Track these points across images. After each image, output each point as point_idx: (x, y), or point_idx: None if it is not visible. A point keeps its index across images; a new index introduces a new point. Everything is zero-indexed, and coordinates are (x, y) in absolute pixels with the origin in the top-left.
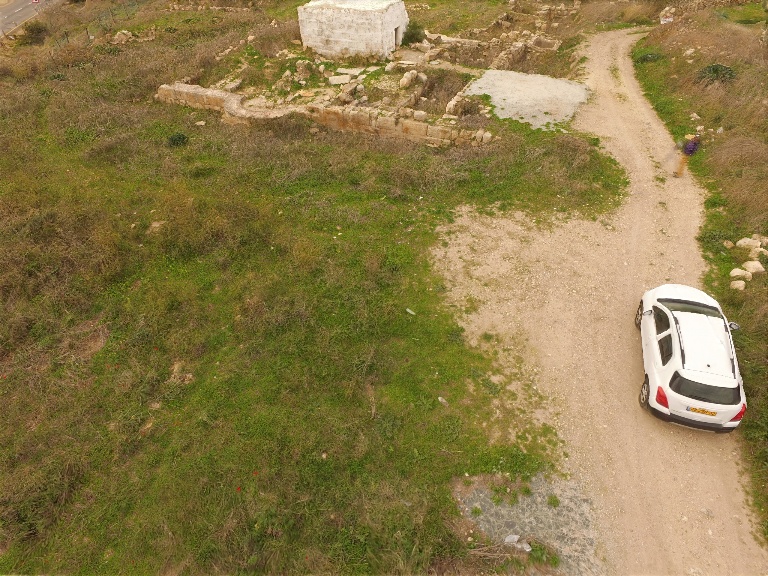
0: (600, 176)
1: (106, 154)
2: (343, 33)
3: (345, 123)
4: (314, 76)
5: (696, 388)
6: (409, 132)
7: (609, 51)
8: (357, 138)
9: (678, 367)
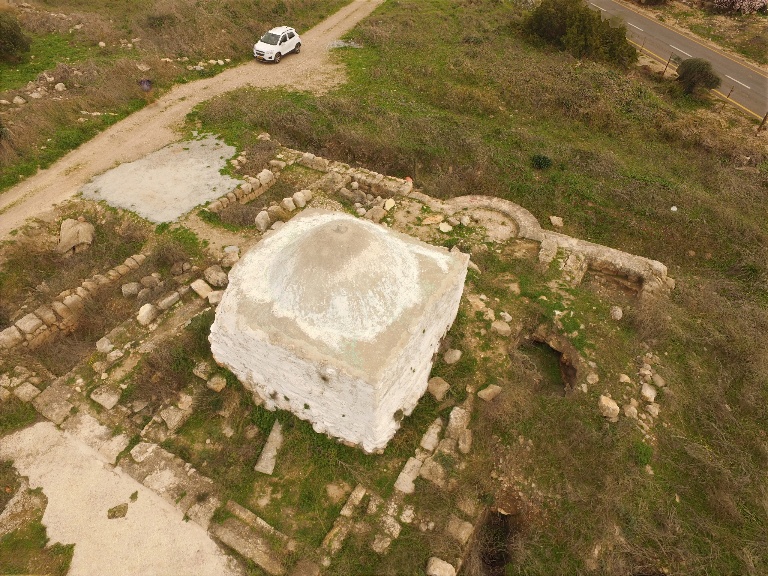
0: None
1: None
2: None
3: None
4: None
5: None
6: None
7: None
8: None
9: None
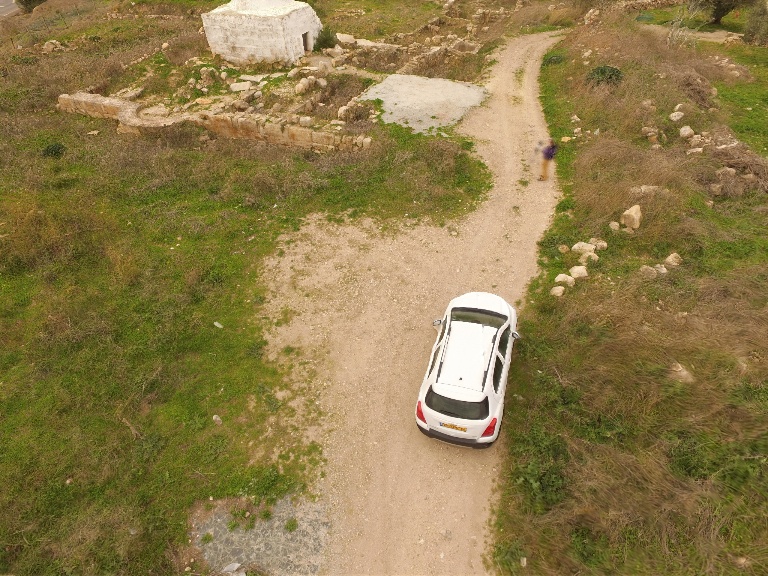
0: (466, 180)
1: None
2: (247, 39)
3: (235, 130)
4: (217, 83)
5: (446, 403)
6: (296, 138)
7: (523, 54)
8: (245, 145)
9: (433, 381)
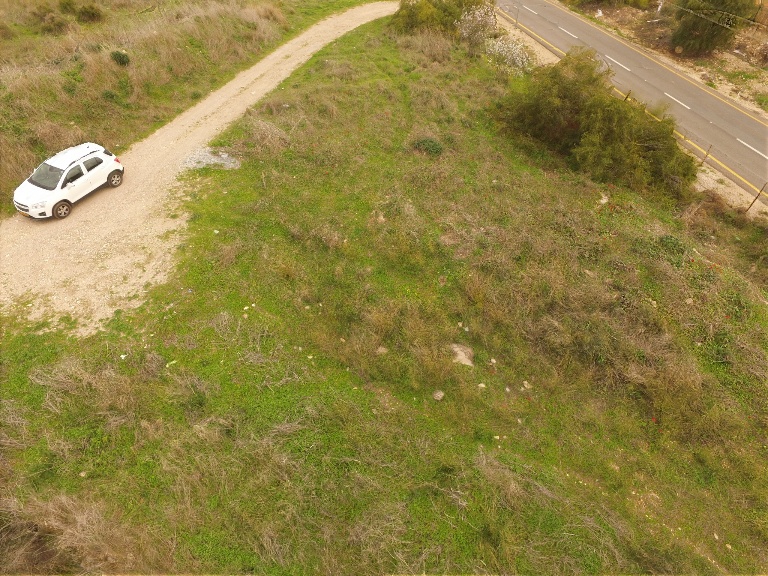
0: None
1: (678, 573)
2: None
3: None
4: None
5: None
6: None
7: None
8: None
9: (101, 152)
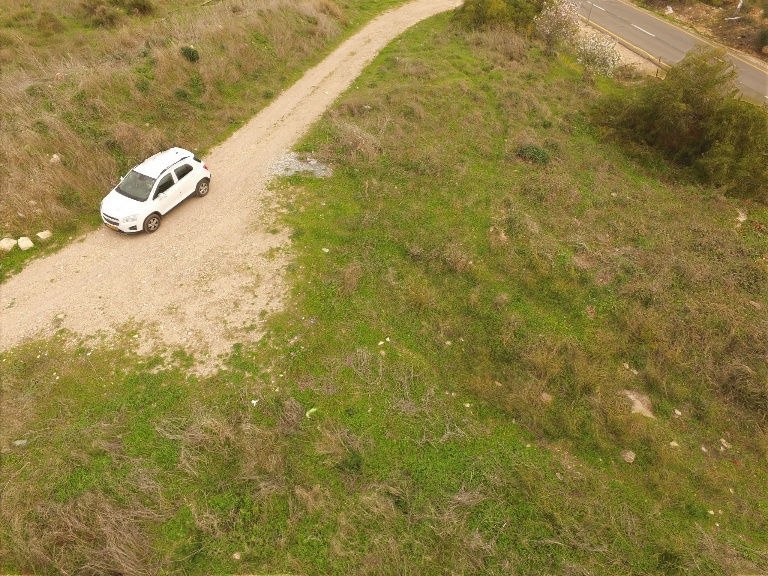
0: None
1: None
2: None
3: None
4: None
5: None
6: None
7: None
8: None
9: (191, 158)
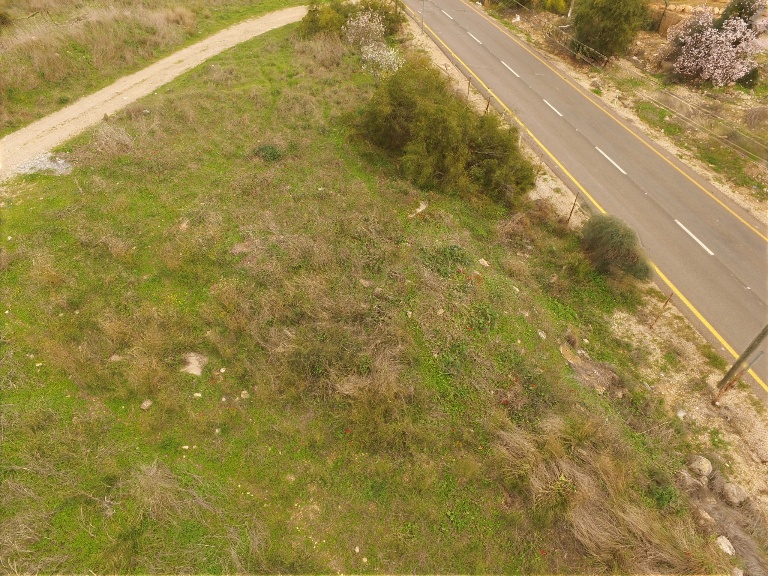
0: None
1: None
2: None
3: None
4: None
5: None
6: None
7: None
8: None
9: None
